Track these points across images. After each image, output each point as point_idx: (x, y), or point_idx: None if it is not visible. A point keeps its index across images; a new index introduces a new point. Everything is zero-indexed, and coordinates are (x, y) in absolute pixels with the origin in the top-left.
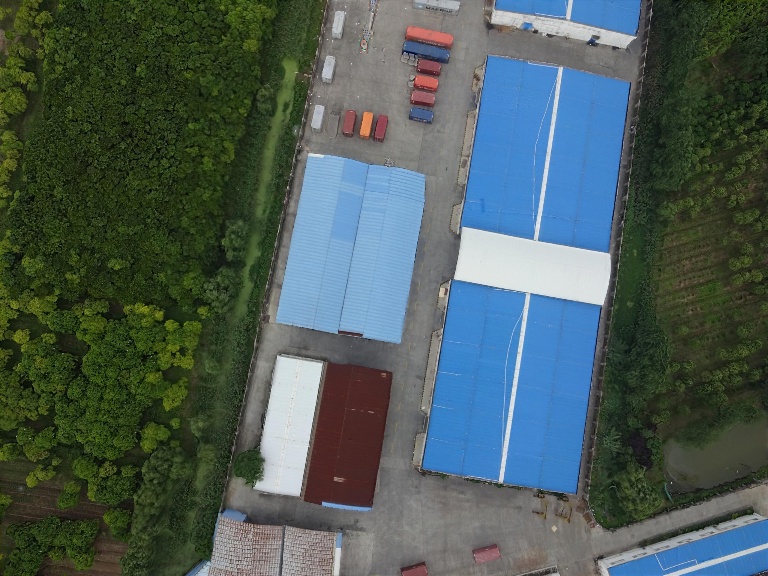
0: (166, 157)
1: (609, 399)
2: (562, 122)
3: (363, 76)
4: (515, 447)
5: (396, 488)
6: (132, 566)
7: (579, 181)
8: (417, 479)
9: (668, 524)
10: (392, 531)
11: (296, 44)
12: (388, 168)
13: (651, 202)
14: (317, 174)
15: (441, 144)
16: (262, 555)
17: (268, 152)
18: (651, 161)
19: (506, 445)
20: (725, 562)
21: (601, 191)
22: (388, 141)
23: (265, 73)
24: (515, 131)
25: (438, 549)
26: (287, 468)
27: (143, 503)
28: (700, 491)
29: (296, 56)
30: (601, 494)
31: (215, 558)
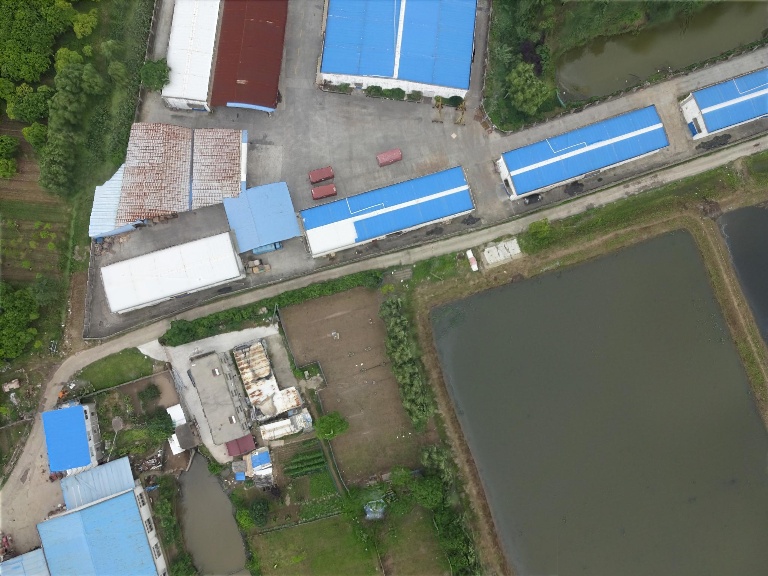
0: None
1: (500, 18)
2: None
3: None
4: (408, 48)
5: (301, 105)
6: (49, 161)
7: None
8: (321, 97)
9: (562, 127)
10: (299, 143)
11: None
12: None
13: None
14: None
15: None
16: (172, 152)
17: None
18: None
19: (399, 45)
20: (613, 143)
21: None
22: None
23: None
24: None
25: (344, 158)
26: (192, 76)
27: (57, 107)
28: (591, 97)
29: None
30: (496, 100)
31: (129, 159)
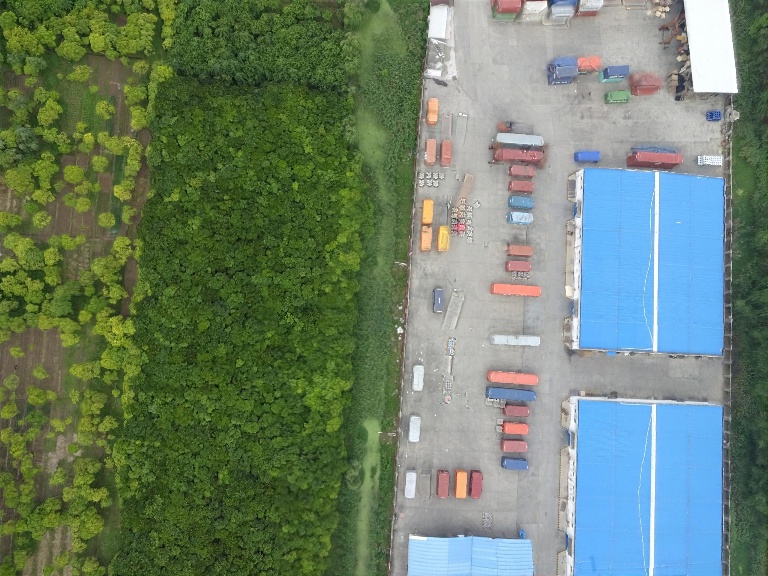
0: (264, 570)
1: None
2: (662, 464)
3: (449, 427)
4: None
5: None
6: None
7: (685, 522)
8: None
9: None
10: None
11: (377, 405)
12: (493, 540)
13: (752, 520)
14: (422, 559)
15: (537, 488)
16: None
17: (361, 524)
18: (749, 480)
19: None
20: None
21: (707, 528)
22: (483, 494)
23: (348, 441)
24: (616, 479)
25: None
26: None
27: None
28: None
29: (378, 417)
30: None
31: None
